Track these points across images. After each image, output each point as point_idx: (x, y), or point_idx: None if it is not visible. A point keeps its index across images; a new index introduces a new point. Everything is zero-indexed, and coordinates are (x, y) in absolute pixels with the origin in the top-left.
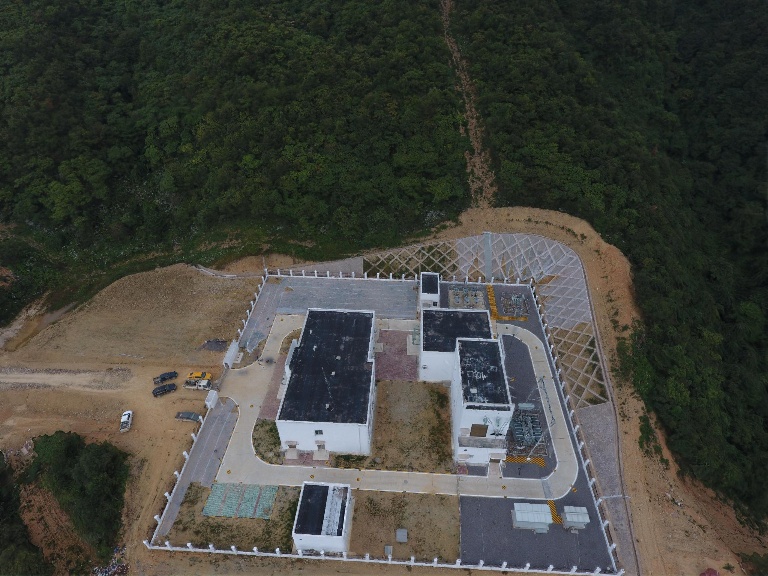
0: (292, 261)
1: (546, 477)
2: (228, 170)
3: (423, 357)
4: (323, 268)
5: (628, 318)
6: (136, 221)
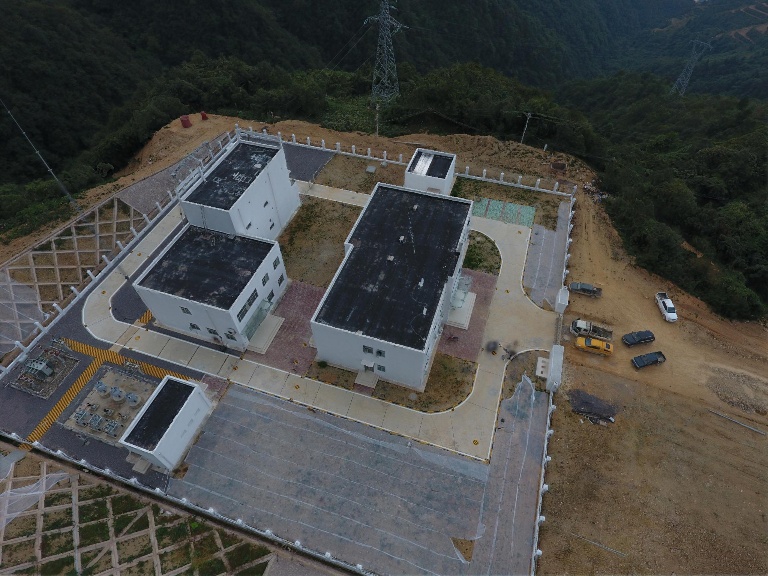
0: None
1: None
2: None
3: None
4: None
5: None
6: None
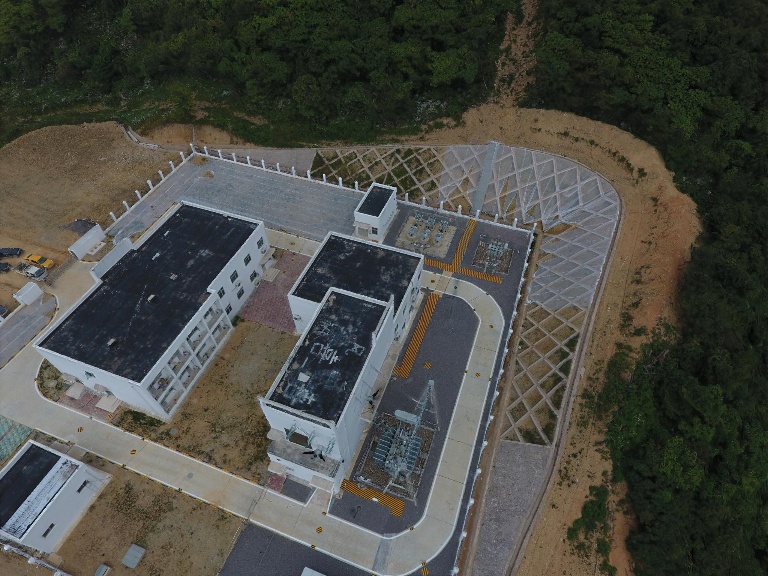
0: (229, 139)
1: (392, 535)
2: (183, 6)
3: (292, 303)
4: (263, 155)
5: (651, 317)
6: (86, 63)
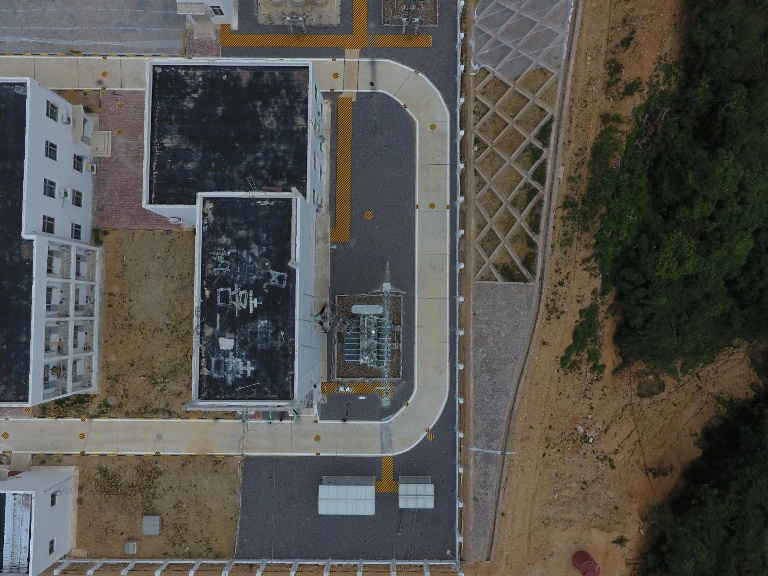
0: None
1: (389, 418)
2: None
3: (155, 211)
4: None
5: (648, 60)
6: None
